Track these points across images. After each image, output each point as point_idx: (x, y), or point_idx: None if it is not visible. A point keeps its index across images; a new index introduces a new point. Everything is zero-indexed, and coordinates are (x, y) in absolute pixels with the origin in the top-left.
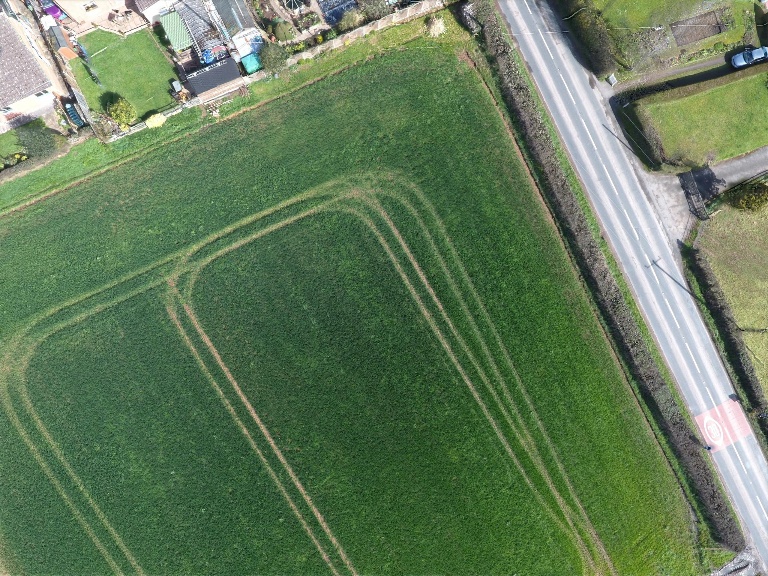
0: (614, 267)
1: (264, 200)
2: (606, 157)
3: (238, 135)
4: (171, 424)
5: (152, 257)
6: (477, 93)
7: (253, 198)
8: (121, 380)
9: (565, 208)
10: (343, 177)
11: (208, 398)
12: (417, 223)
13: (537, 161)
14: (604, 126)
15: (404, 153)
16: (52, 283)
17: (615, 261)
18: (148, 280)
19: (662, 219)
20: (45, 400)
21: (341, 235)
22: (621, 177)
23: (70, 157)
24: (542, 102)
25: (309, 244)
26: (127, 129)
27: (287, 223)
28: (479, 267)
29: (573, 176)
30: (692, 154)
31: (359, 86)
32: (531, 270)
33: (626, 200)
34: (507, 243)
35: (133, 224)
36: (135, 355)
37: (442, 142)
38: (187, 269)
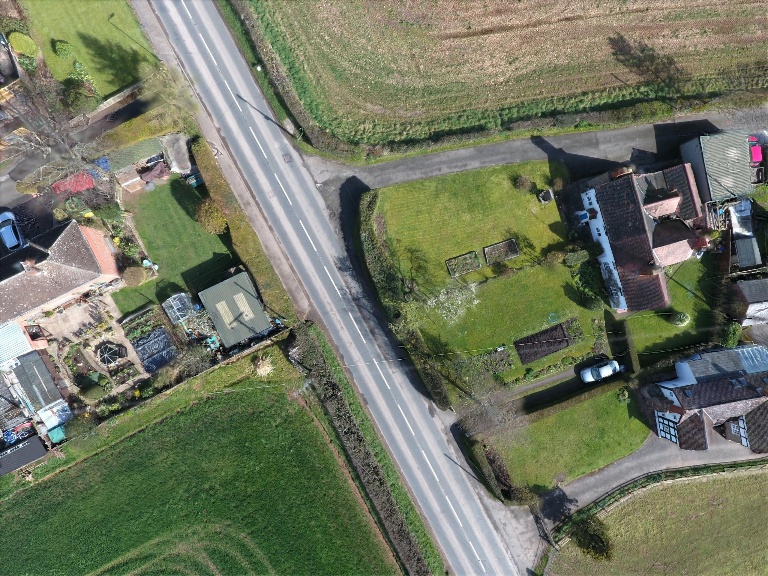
0: None
1: (83, 566)
2: (449, 488)
3: (54, 499)
4: None
5: None
6: (308, 434)
7: (70, 566)
8: None
9: (402, 555)
10: (168, 533)
11: None
12: None
13: (373, 503)
14: (446, 455)
15: (232, 504)
16: None
17: None
18: None
19: (510, 548)
20: None
21: None
22: (465, 508)
23: None
24: (379, 436)
25: None
26: None
27: None
28: None
29: (413, 512)
30: (540, 479)
31: (183, 435)
32: None
33: (471, 531)
34: None
35: None
36: None
37: (272, 488)
38: None
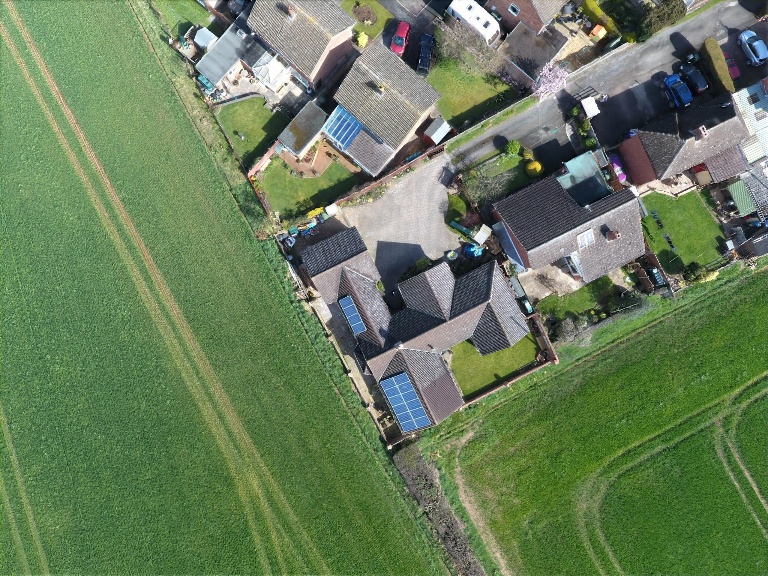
0: None
1: None
2: None
3: None
4: (720, 553)
5: (703, 401)
6: None
7: None
8: (679, 514)
9: None
10: None
11: (750, 529)
12: None
13: None
14: None
15: None
16: (622, 427)
17: None
18: (700, 422)
19: None
20: (617, 534)
21: None
22: None
23: None
24: None
25: None
26: (684, 285)
27: None
28: None
29: None
30: None
31: None
32: None
33: None
34: None
35: (686, 371)
36: (691, 491)
37: None
38: (731, 411)
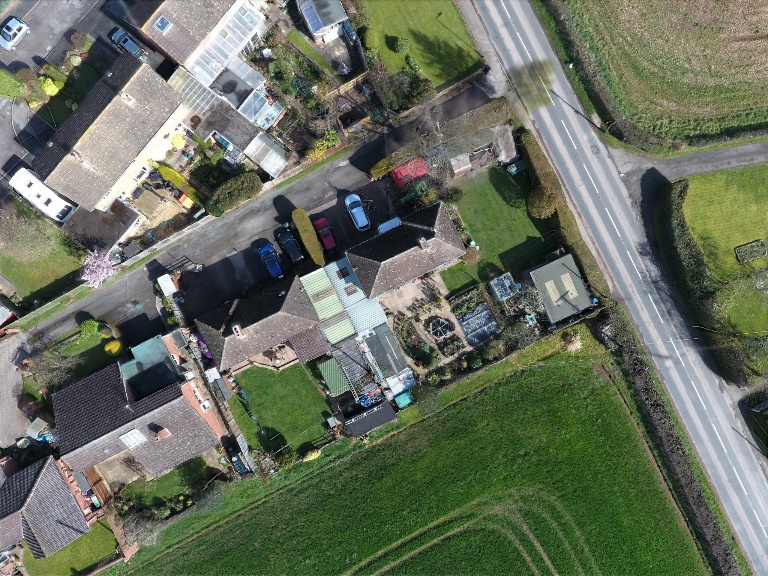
0: (745, 566)
1: (413, 523)
2: (736, 459)
3: (387, 460)
4: None
5: None
6: (613, 406)
7: (403, 522)
8: None
9: (701, 519)
10: (487, 495)
11: None
12: (558, 536)
13: (672, 471)
14: (733, 429)
15: (545, 469)
16: None
17: (746, 561)
18: None
19: None
20: None
21: (486, 552)
22: (750, 478)
23: (230, 493)
24: (674, 409)
25: (456, 563)
26: None
27: (434, 543)
28: (617, 575)
29: (705, 481)
30: None
31: (500, 404)
32: (666, 575)
33: (755, 500)
34: (643, 550)
35: (290, 554)
36: None
37: (580, 455)
38: None
